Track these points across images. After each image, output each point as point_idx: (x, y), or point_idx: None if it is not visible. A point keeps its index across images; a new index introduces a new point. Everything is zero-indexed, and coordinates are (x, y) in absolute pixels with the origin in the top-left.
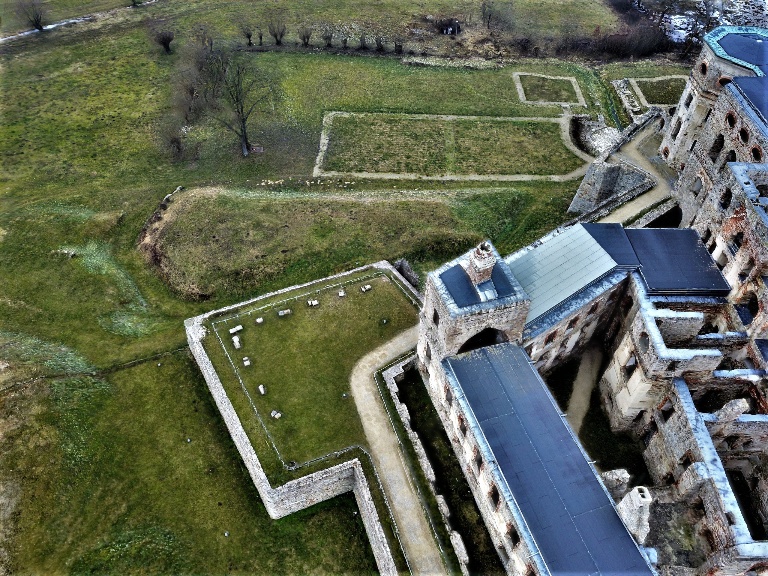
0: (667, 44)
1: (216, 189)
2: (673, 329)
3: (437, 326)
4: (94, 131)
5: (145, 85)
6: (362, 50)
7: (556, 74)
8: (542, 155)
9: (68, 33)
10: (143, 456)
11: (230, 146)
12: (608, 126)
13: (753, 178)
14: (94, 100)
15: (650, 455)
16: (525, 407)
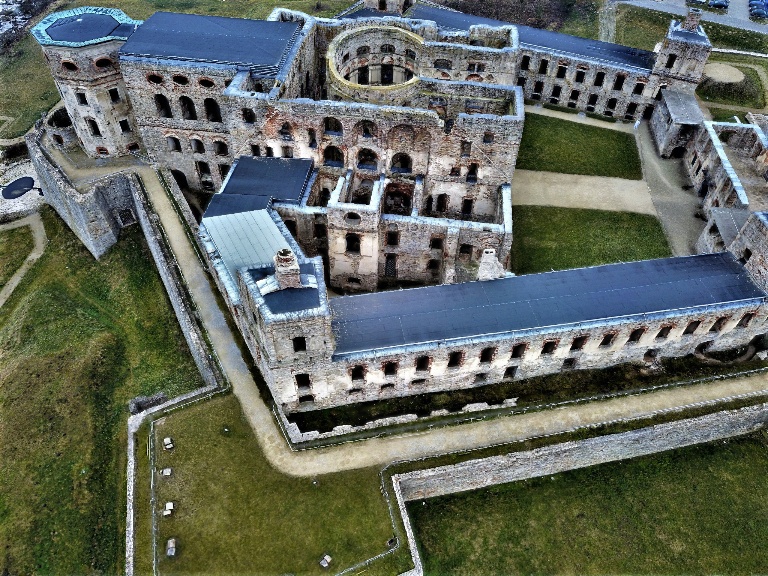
0: None
1: None
2: None
3: (301, 350)
4: None
5: None
6: None
7: None
8: None
9: None
10: None
11: None
12: None
13: None
14: None
15: (405, 272)
16: (395, 309)
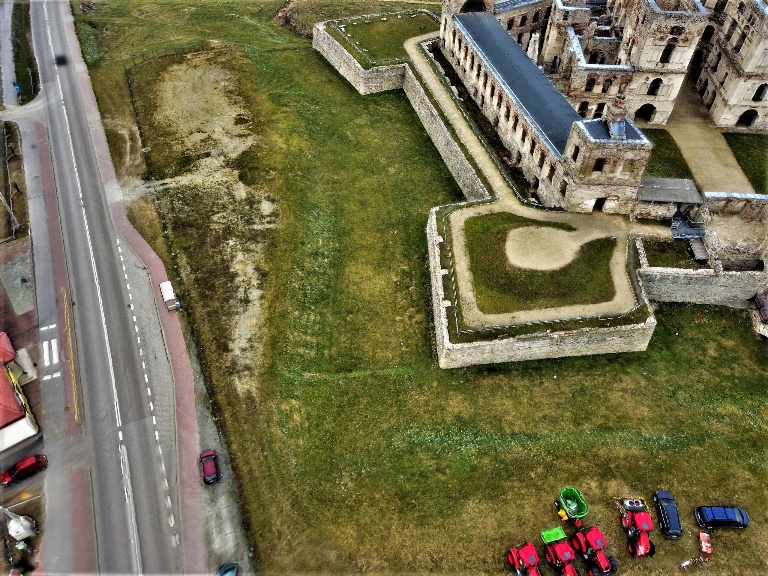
0: None
1: None
2: None
3: None
4: None
5: None
6: None
7: None
8: None
9: None
10: (295, 74)
11: None
12: None
13: None
14: None
15: None
16: (490, 28)
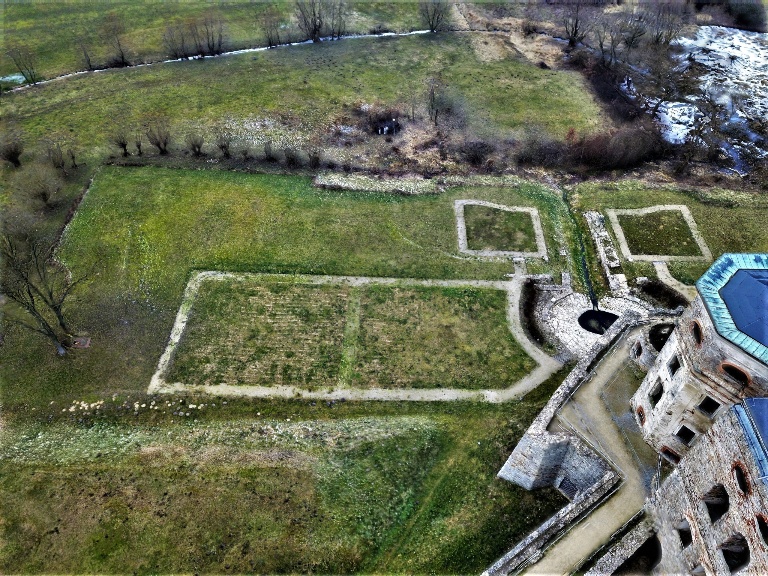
0: (661, 151)
1: None
2: None
3: None
4: None
5: None
6: (267, 162)
7: (512, 203)
8: (477, 351)
9: None
10: None
11: None
12: (575, 291)
13: None
14: None
15: None
16: None
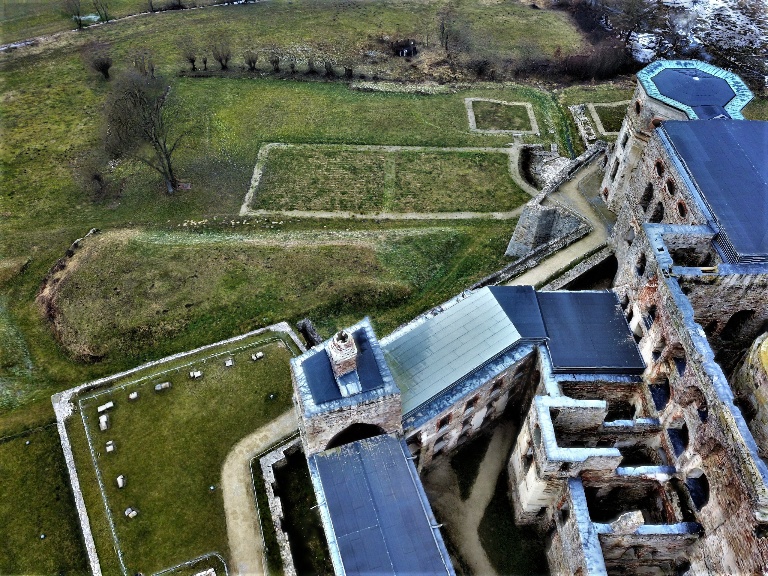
0: (631, 65)
1: (131, 232)
2: (574, 418)
3: None
4: (16, 166)
5: (78, 115)
6: (311, 74)
7: (511, 99)
8: (486, 190)
9: (7, 59)
10: None
11: (156, 182)
12: (561, 156)
13: (671, 241)
14: (21, 132)
15: (552, 558)
16: (392, 518)
